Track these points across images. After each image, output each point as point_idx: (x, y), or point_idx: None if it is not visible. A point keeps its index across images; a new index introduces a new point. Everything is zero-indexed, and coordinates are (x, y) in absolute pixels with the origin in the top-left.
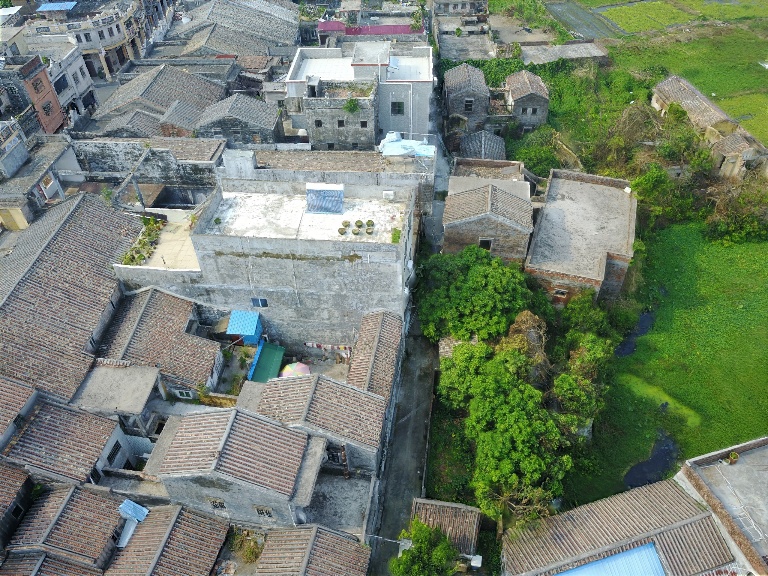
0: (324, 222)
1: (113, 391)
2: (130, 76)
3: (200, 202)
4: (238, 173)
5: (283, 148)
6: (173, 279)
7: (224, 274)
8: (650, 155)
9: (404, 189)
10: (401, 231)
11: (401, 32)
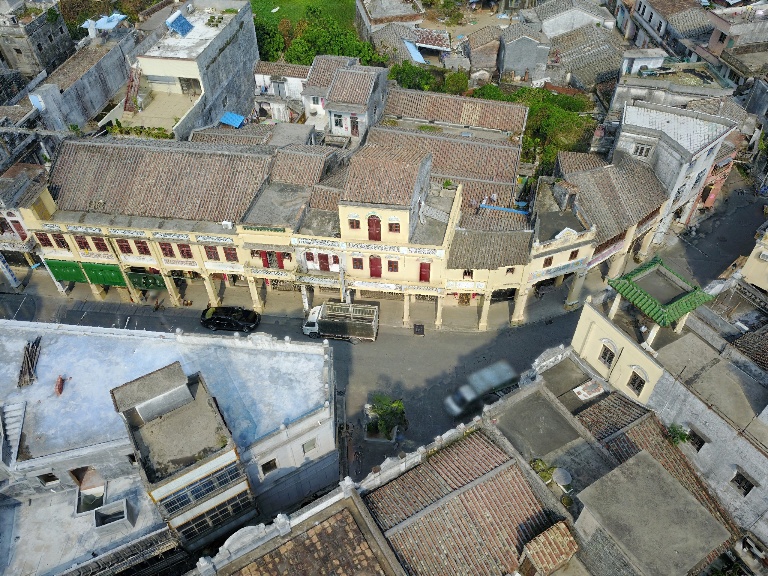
0: (199, 32)
1: (292, 137)
2: None
3: (43, 161)
4: (55, 106)
5: (32, 87)
6: (198, 113)
7: (211, 87)
8: (130, 1)
9: (191, 0)
10: (237, 1)
11: None
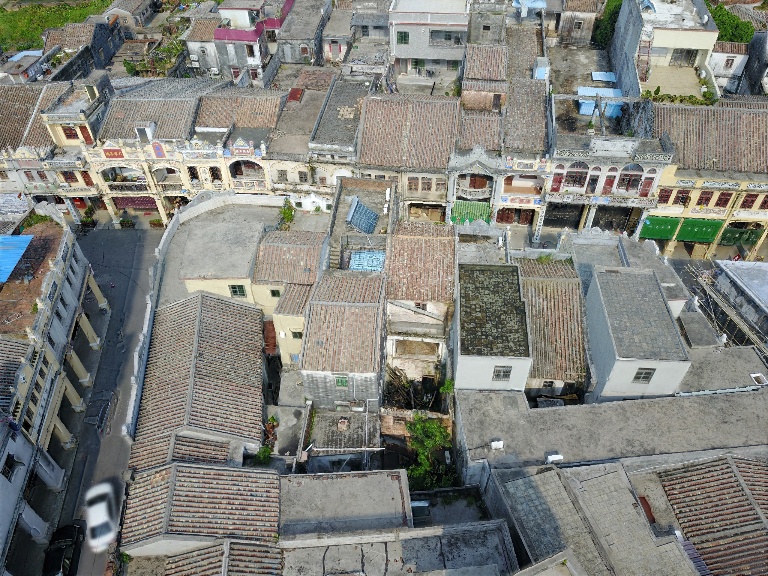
0: (664, 8)
1: None
2: (356, 138)
3: None
4: None
5: None
6: None
7: None
8: None
9: None
10: None
11: (292, 3)
